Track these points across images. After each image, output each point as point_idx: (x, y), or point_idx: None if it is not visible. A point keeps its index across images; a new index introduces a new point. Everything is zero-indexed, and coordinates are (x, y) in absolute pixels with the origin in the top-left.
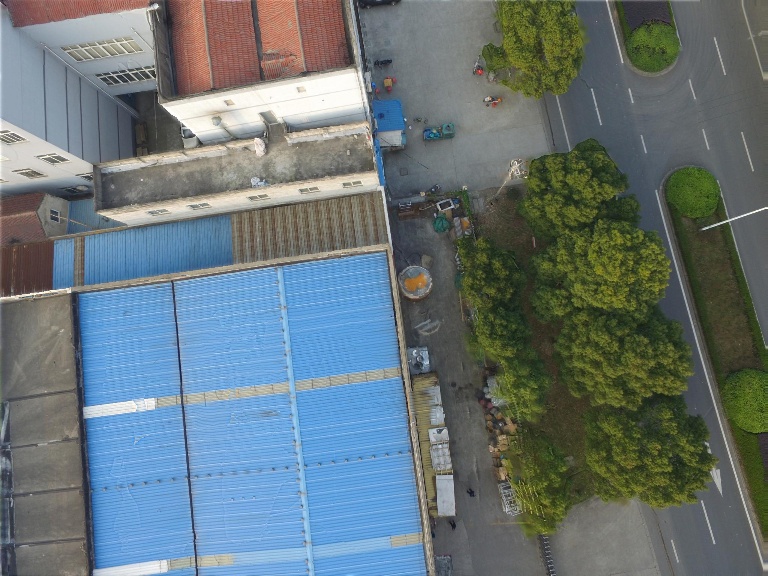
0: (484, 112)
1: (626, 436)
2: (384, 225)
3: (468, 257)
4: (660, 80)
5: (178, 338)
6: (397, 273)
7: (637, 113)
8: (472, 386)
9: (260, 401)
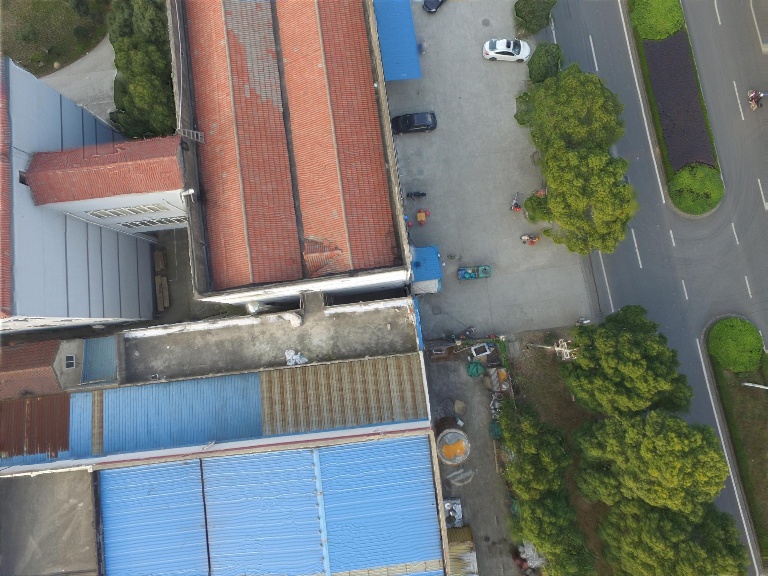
0: (520, 249)
1: None
2: (422, 391)
3: (513, 440)
4: (702, 222)
5: (206, 520)
6: None
7: (678, 256)
8: (506, 541)
9: None
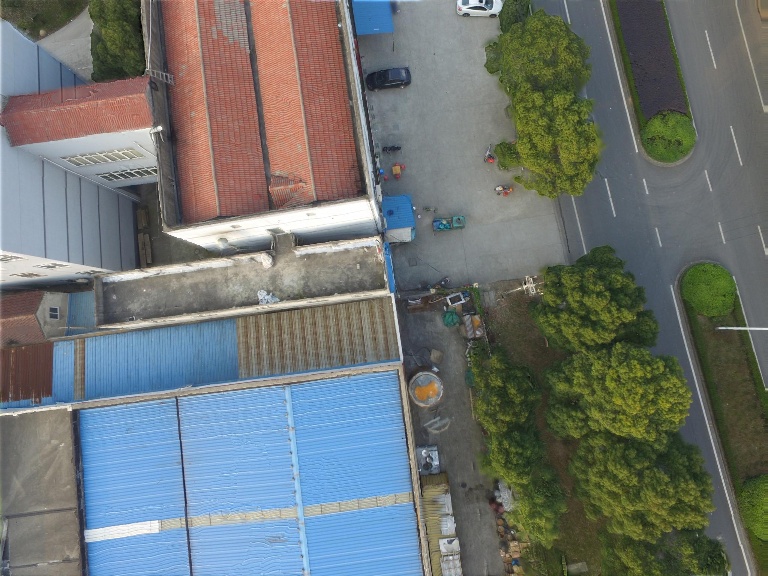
0: (495, 201)
1: (645, 572)
2: (394, 333)
3: (482, 376)
4: (675, 170)
5: (182, 457)
6: (407, 383)
7: (652, 204)
8: (483, 487)
9: (267, 521)
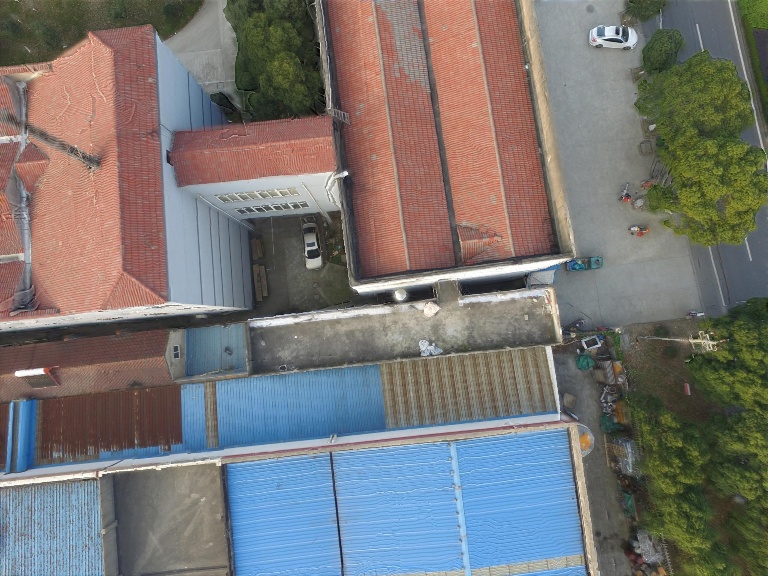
0: (629, 241)
1: None
2: (549, 384)
3: (653, 434)
4: None
5: (338, 515)
6: None
7: None
8: (618, 536)
9: None
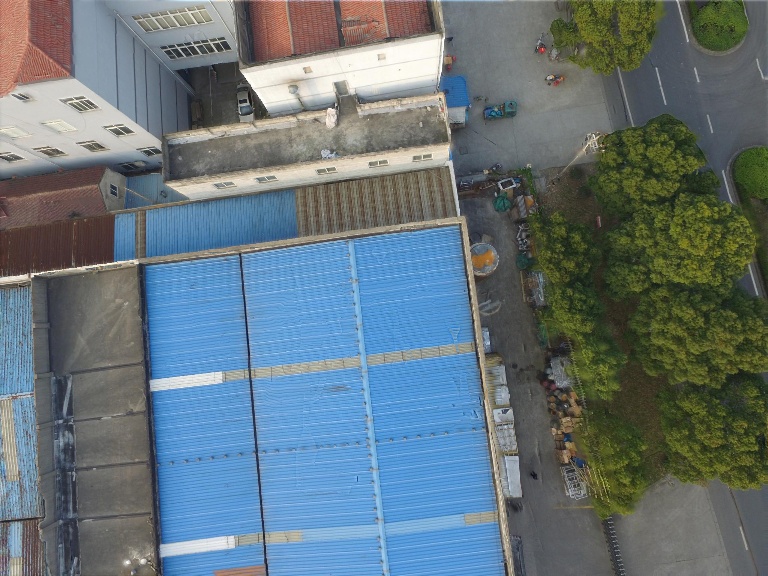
0: (545, 91)
1: (711, 414)
2: (452, 200)
3: (543, 232)
4: (726, 59)
5: (246, 311)
6: None
7: (703, 92)
8: (534, 368)
9: (328, 376)
